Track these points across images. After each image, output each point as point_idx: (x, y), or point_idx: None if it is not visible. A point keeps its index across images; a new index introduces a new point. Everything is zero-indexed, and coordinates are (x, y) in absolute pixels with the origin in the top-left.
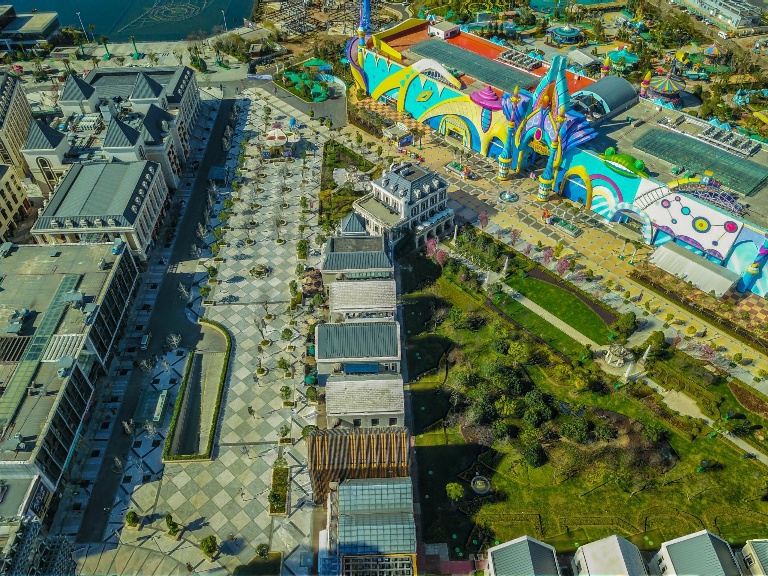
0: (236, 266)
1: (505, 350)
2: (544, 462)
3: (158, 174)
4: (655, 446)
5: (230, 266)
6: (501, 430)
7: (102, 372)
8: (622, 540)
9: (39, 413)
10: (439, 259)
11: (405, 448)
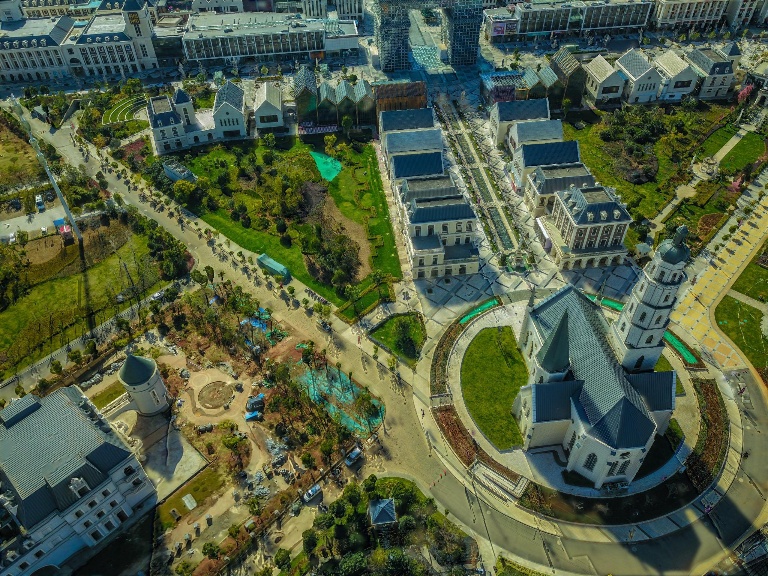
0: (679, 53)
1: (678, 126)
2: (605, 141)
3: (721, 1)
4: (641, 176)
5: (677, 51)
6: (613, 119)
7: (579, 34)
8: (561, 124)
9: (542, 7)
10: (739, 96)
11: (573, 69)
